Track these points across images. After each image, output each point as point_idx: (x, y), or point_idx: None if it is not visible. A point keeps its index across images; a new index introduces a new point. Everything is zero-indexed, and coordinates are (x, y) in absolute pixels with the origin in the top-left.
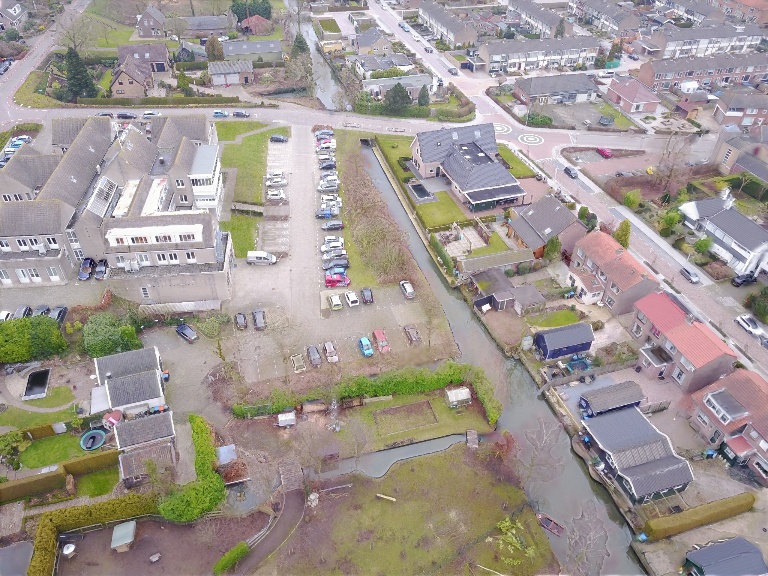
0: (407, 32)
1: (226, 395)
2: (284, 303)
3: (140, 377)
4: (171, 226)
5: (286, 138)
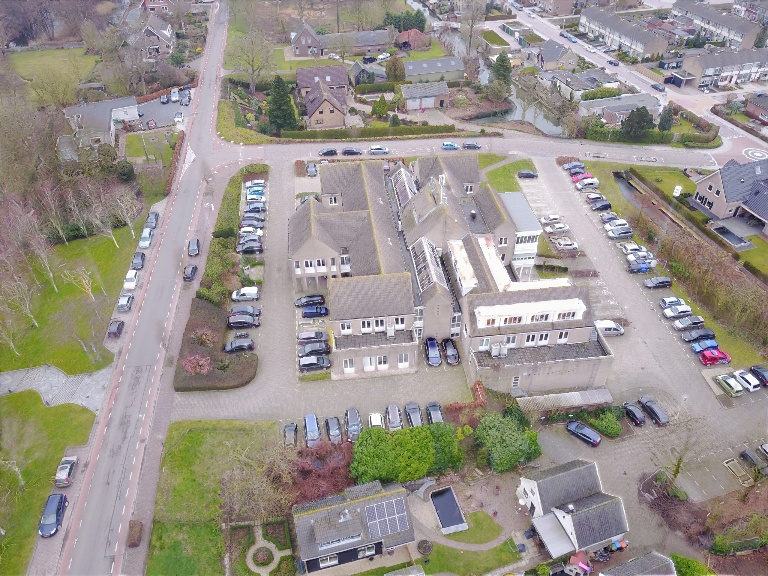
0: (574, 43)
1: (683, 521)
2: (667, 388)
3: (604, 508)
4: (545, 302)
5: (535, 173)
